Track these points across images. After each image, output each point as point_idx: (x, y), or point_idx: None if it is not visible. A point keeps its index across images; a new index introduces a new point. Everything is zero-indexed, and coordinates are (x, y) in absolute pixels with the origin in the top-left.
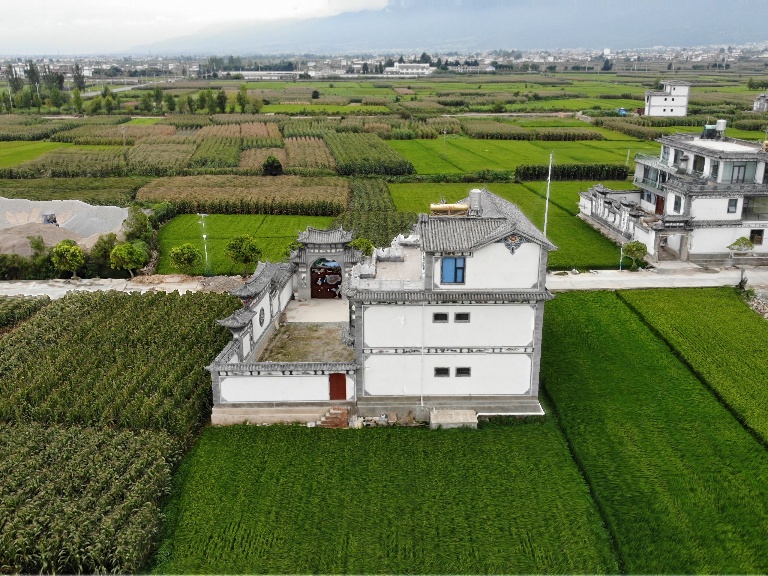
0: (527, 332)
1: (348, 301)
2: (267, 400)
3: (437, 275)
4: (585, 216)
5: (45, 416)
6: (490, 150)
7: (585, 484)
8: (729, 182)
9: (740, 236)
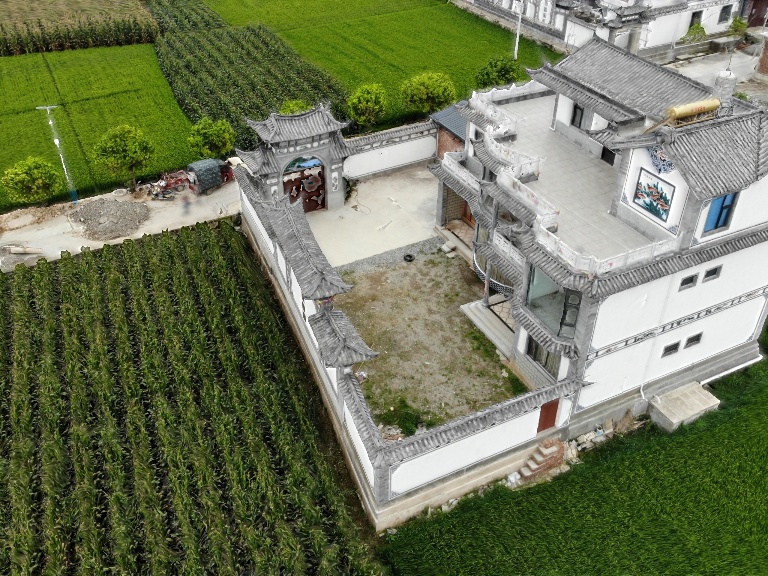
0: None
1: (339, 211)
2: (455, 469)
3: (701, 226)
4: (466, 4)
5: None
6: None
7: None
8: None
9: (683, 22)
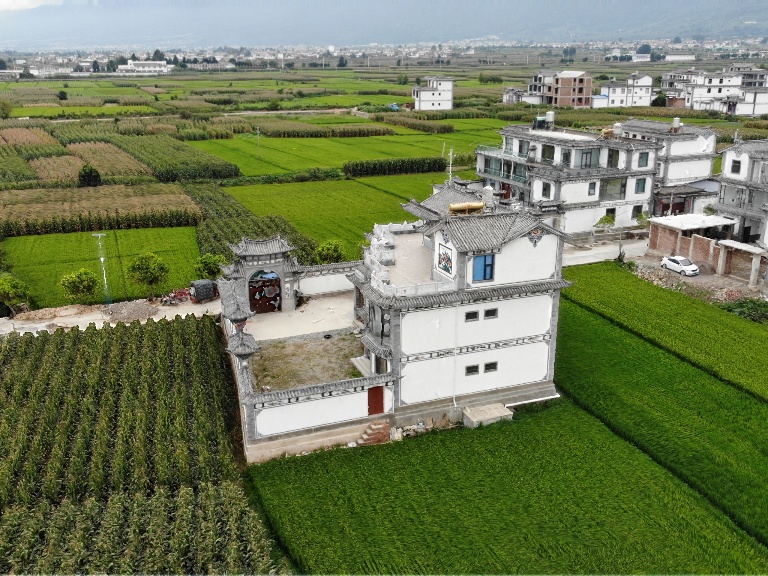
0: (545, 320)
1: (290, 313)
2: (305, 427)
3: (469, 274)
4: None
5: (56, 490)
6: (297, 148)
7: (643, 453)
8: (579, 168)
9: (599, 215)
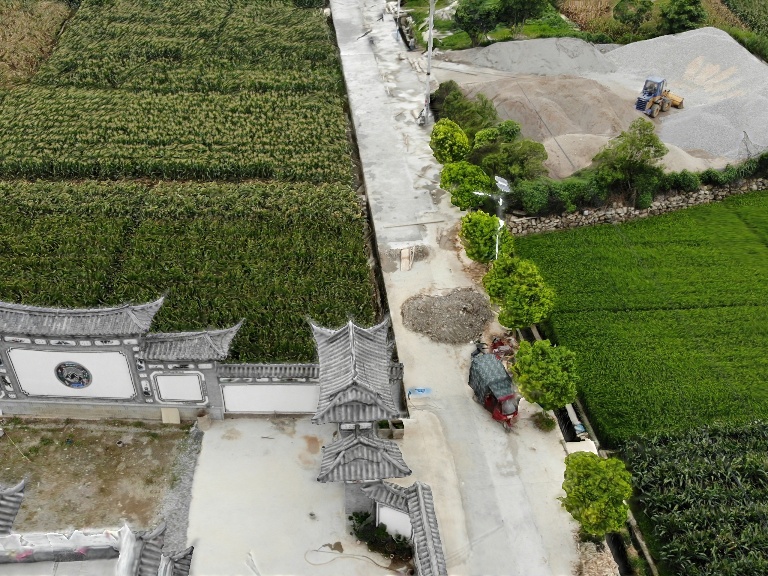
0: None
1: (334, 521)
2: None
3: None
4: None
5: None
6: None
7: None
8: None
9: None
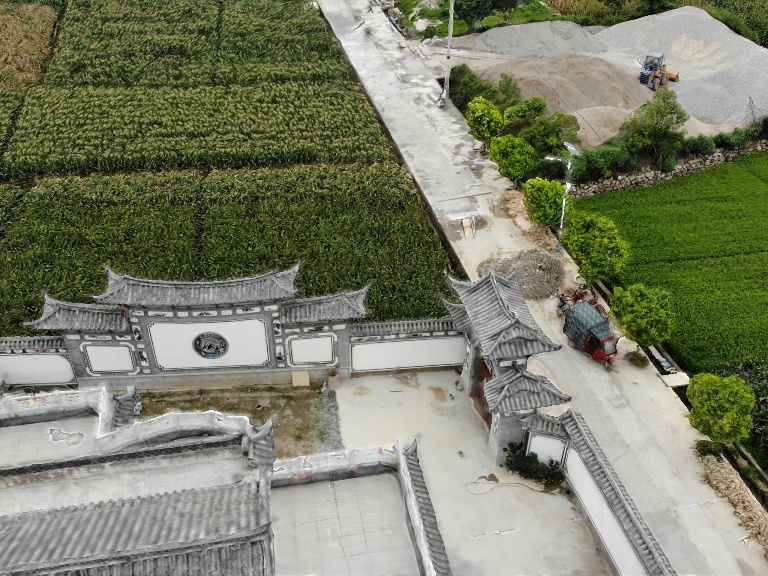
0: None
1: (482, 456)
2: None
3: None
4: None
5: (4, 263)
6: None
7: None
8: None
9: None
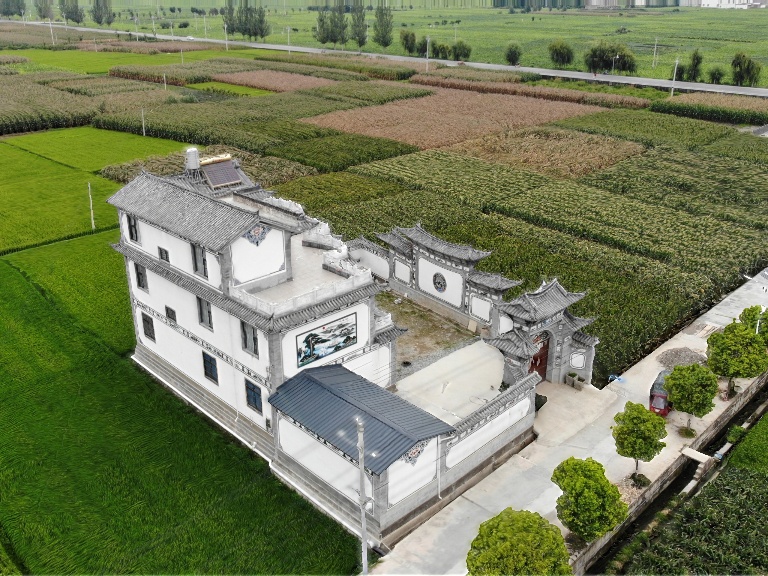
0: None
1: None
2: None
3: None
4: None
5: None
6: None
7: None
8: None
9: None
